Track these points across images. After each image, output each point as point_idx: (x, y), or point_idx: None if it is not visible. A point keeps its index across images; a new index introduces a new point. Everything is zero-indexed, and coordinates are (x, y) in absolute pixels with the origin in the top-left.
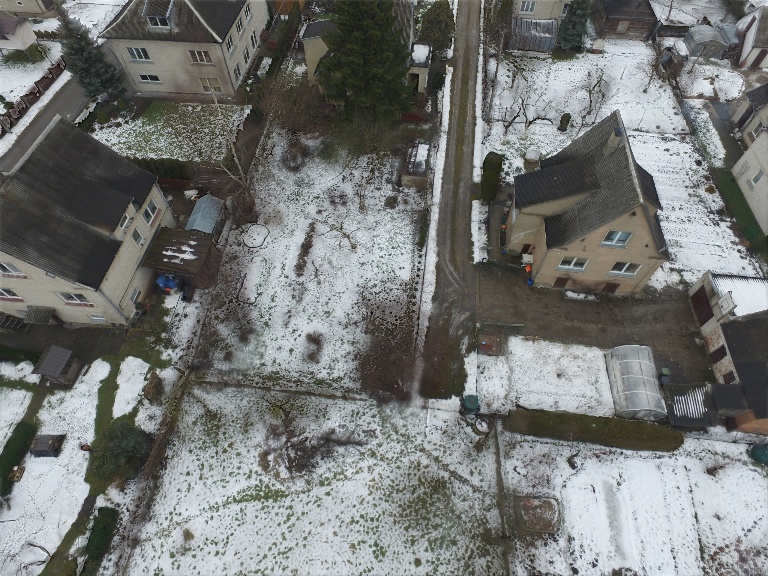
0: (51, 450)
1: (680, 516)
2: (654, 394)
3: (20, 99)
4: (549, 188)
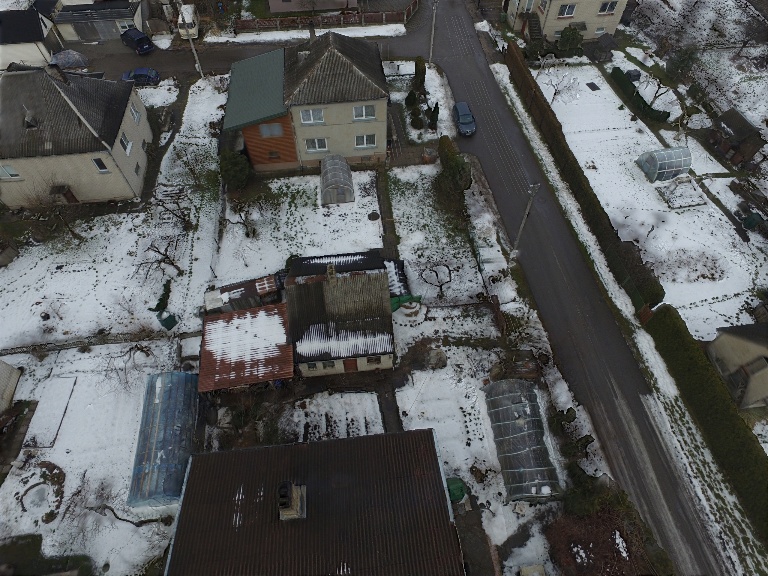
0: None
1: None
2: None
3: None
4: None
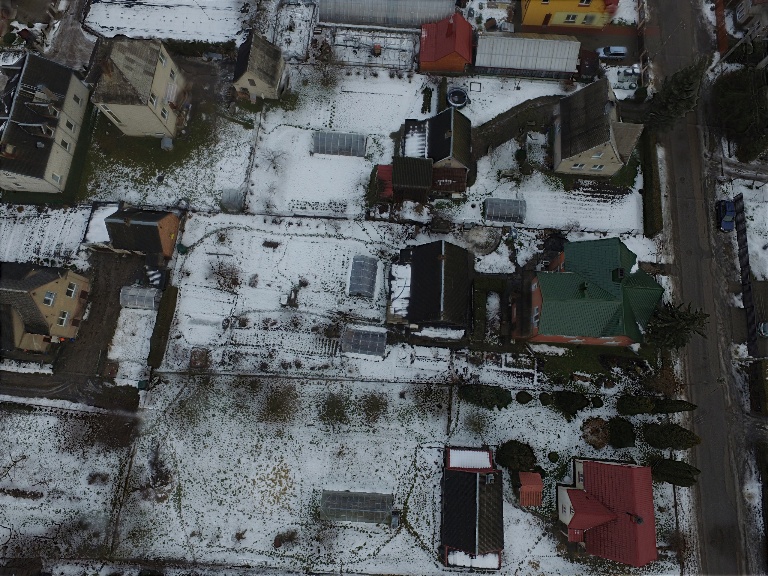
0: None
1: (205, 294)
2: (147, 293)
3: None
4: (3, 330)
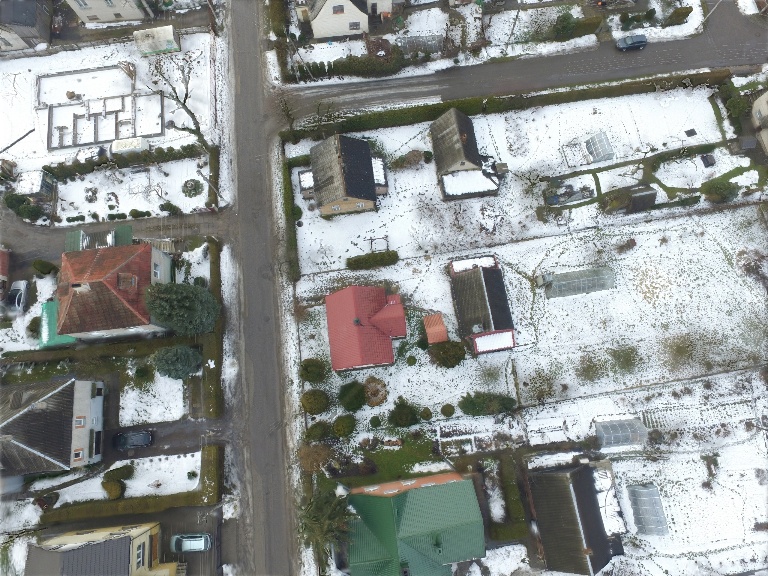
0: (710, 164)
1: None
2: None
3: None
4: None
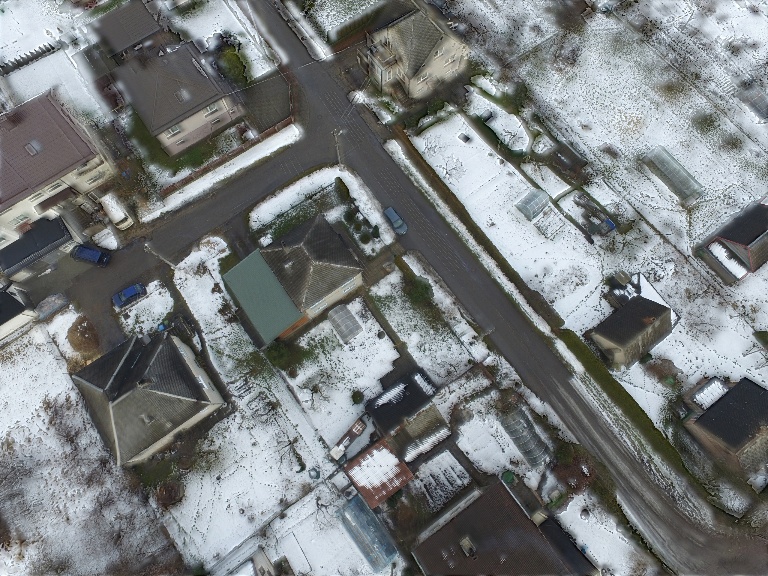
0: None
1: None
2: None
3: (230, 31)
4: None
